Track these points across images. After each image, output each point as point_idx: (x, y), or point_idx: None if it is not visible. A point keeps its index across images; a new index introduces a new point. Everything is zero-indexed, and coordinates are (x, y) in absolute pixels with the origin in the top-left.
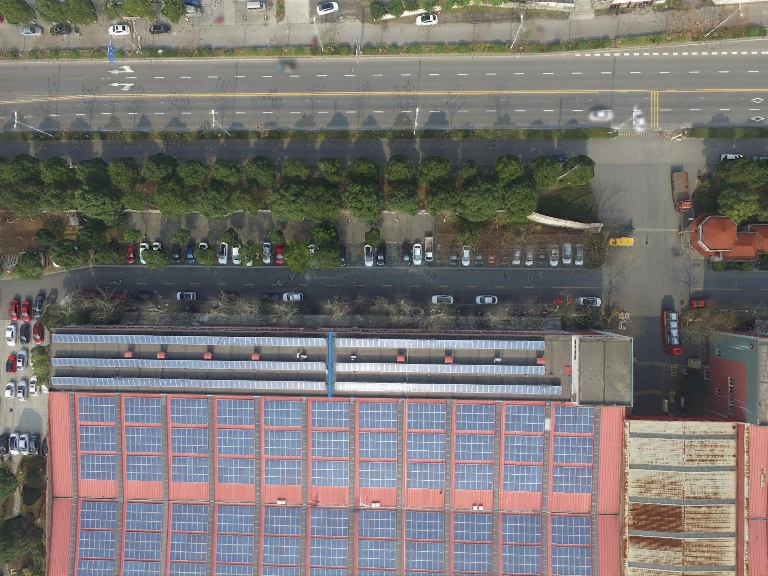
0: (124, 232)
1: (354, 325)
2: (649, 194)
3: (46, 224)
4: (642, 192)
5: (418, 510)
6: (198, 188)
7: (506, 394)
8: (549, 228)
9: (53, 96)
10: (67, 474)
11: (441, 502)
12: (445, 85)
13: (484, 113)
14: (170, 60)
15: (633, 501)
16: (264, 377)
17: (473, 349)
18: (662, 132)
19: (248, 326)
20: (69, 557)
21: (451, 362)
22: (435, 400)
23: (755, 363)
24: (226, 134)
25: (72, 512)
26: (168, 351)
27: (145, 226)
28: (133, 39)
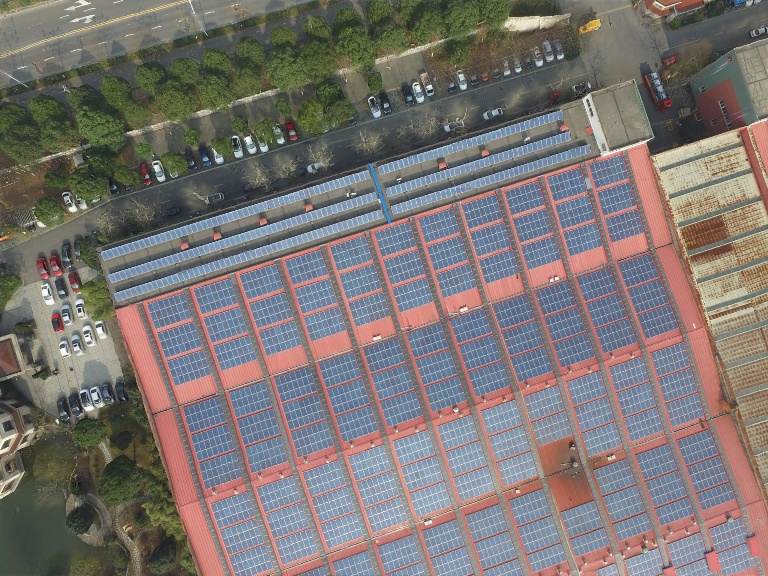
0: None
1: None
2: None
3: None
4: None
5: (503, 300)
6: (194, 88)
7: (544, 168)
8: (525, 35)
9: (14, 49)
10: (159, 386)
11: (520, 286)
12: None
13: None
14: None
15: (681, 226)
16: (323, 226)
17: (502, 138)
18: None
19: None
20: (189, 465)
21: (488, 154)
22: (485, 194)
23: (738, 70)
24: (203, 35)
25: (177, 421)
26: (222, 232)
27: None
28: None
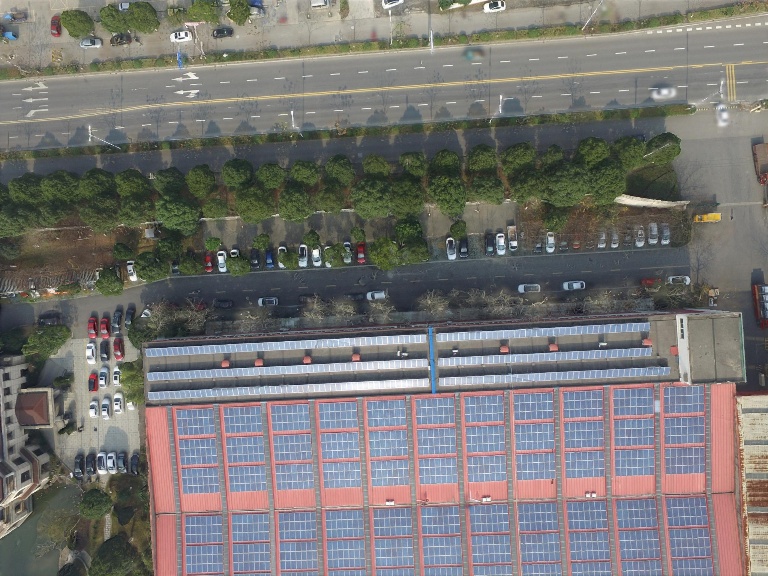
0: (201, 241)
1: (444, 320)
2: (731, 168)
3: (119, 238)
4: (724, 167)
5: (530, 502)
6: (275, 191)
7: (613, 378)
8: (632, 209)
9: (117, 108)
10: (168, 490)
11: (553, 492)
12: (517, 71)
13: (558, 97)
14: (235, 64)
15: (748, 478)
16: (365, 378)
17: (576, 335)
18: (740, 105)
19: (338, 328)
20: (177, 574)
21: (556, 350)
22: (541, 389)
23: None
24: (298, 135)
25: (176, 528)
26: (265, 358)
27: (220, 234)
28: (195, 45)
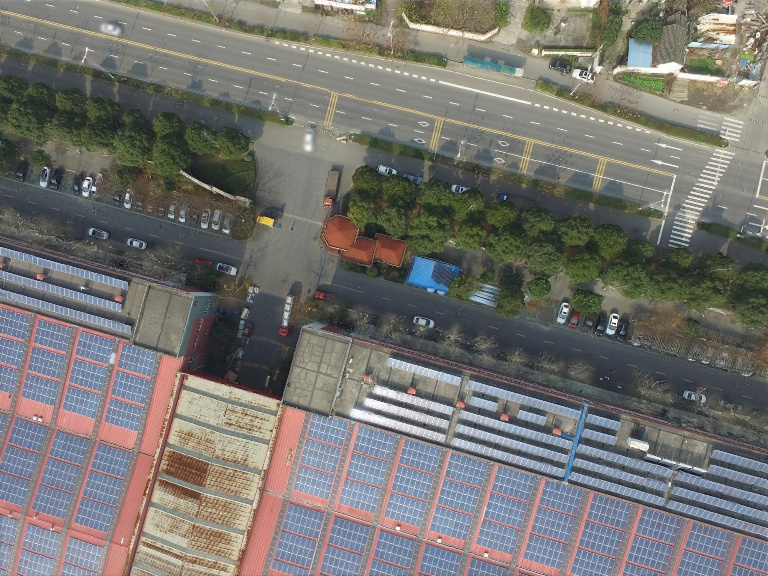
0: None
1: (6, 234)
2: (306, 185)
3: None
4: (301, 182)
5: None
6: None
7: (84, 321)
8: (210, 193)
9: None
10: None
11: (8, 405)
12: (154, 41)
13: (181, 75)
14: None
15: (171, 448)
16: None
17: (67, 274)
18: (331, 131)
19: None
20: None
21: (42, 279)
22: (22, 311)
23: None
24: None
25: None
26: None
27: None
28: None
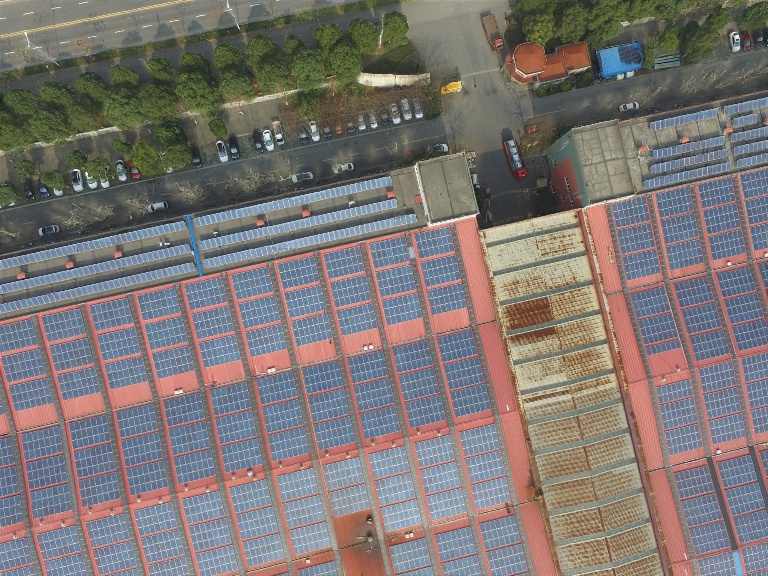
0: None
1: None
2: (467, 42)
3: None
4: (460, 41)
5: (313, 364)
6: None
7: (367, 234)
8: (385, 91)
9: None
10: None
11: (333, 351)
12: None
13: None
14: None
15: (505, 304)
16: (132, 274)
17: (327, 200)
18: None
19: None
20: None
21: (309, 215)
22: (303, 255)
23: (575, 150)
24: (54, 64)
25: None
26: (29, 271)
27: None
28: None
